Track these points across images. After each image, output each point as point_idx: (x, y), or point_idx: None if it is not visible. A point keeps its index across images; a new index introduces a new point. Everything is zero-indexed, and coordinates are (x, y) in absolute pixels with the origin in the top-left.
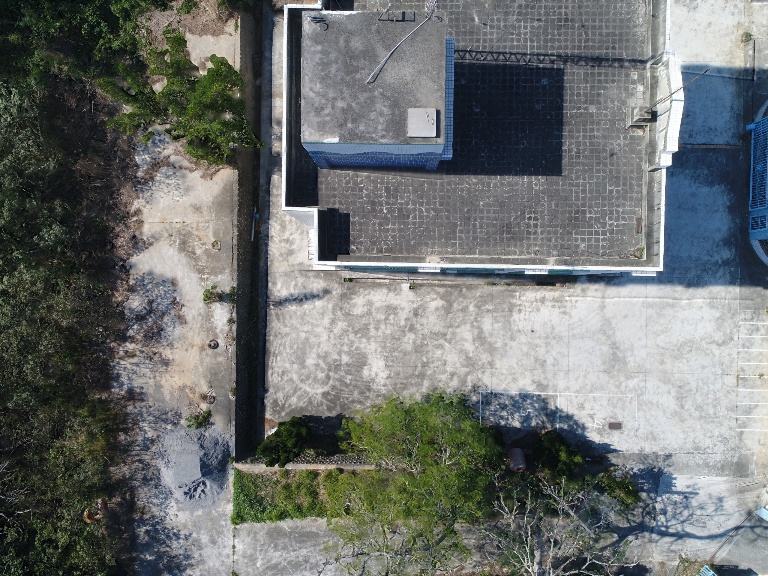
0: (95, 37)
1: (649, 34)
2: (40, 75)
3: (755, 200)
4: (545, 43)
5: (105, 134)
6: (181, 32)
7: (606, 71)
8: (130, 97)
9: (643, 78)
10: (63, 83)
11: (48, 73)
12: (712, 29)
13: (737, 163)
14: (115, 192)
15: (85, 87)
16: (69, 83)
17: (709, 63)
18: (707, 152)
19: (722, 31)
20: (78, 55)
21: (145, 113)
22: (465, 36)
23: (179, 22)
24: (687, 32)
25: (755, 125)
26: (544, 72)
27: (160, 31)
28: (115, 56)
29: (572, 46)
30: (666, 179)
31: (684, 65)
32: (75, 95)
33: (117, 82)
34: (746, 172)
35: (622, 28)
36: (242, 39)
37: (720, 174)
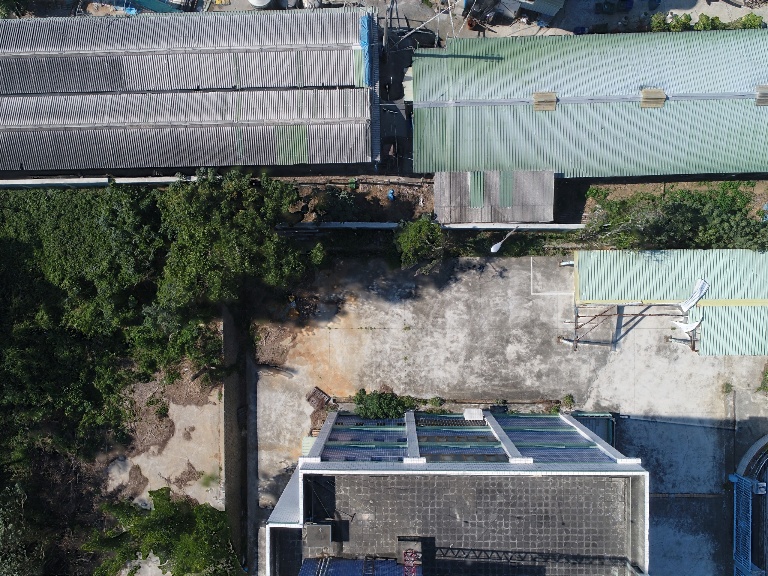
0: (79, 413)
1: (629, 537)
2: (24, 453)
3: (739, 554)
4: (526, 540)
5: (91, 503)
6: (165, 402)
7: (587, 568)
8: (115, 546)
9: (624, 574)
10: (47, 457)
11: (32, 448)
12: (693, 380)
13: (720, 511)
14: (102, 563)
15: (70, 461)
16: (54, 456)
17: (691, 413)
18: (691, 501)
19: (703, 382)
20: (62, 431)
21: (130, 558)
22: (447, 533)
23: (163, 393)
24: (668, 383)
25: (737, 479)
26: (526, 569)
27: (144, 402)
28: (99, 429)
29: (553, 543)
30: (651, 528)
31: (666, 416)
32: (60, 472)
33: (102, 454)
34: (729, 520)
35: (602, 525)
36: (226, 405)
37: (704, 523)
